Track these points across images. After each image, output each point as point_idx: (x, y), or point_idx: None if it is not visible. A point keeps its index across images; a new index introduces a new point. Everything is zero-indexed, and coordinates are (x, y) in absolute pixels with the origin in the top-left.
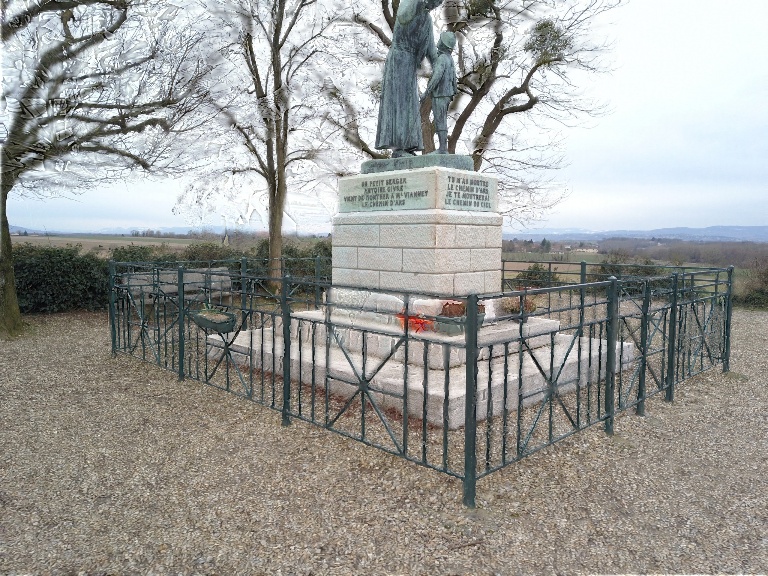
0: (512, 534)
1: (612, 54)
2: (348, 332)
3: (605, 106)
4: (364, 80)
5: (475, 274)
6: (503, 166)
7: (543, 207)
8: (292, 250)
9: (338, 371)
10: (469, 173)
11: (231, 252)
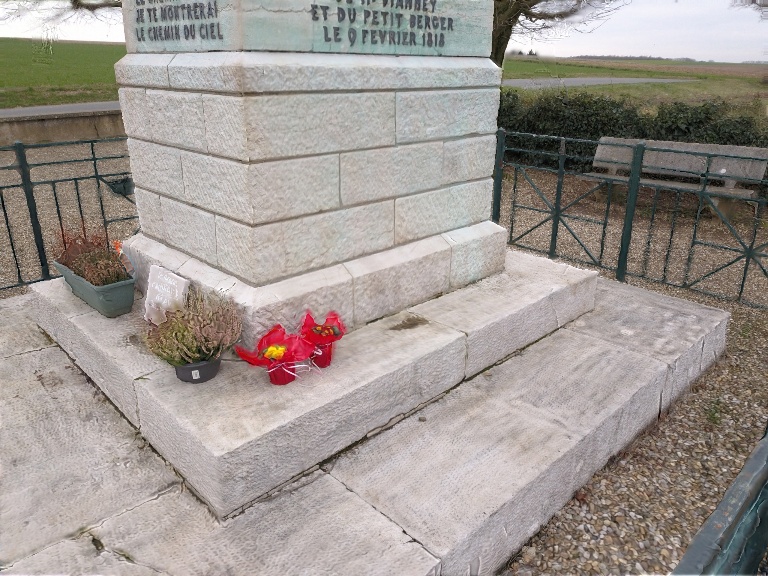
0: None
1: None
2: None
3: None
4: None
5: (197, 212)
6: None
7: None
8: None
9: None
10: None
11: None
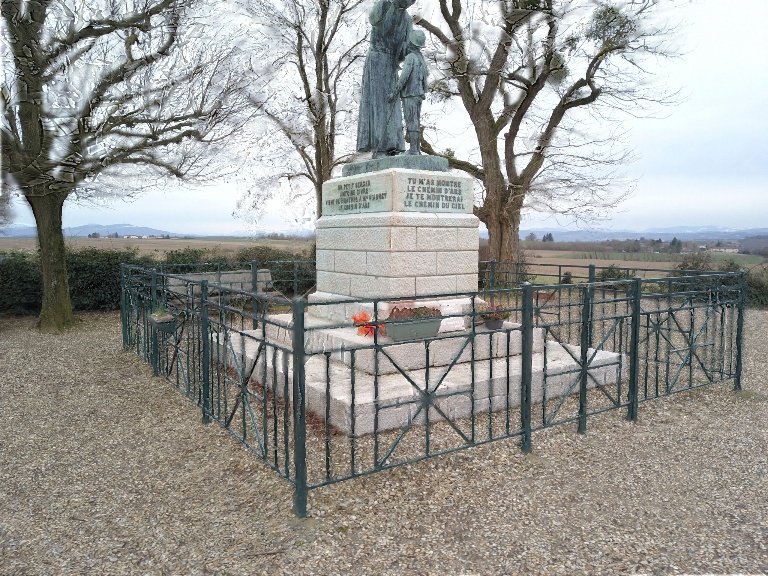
0: (324, 547)
1: (679, 37)
2: (312, 334)
3: (675, 94)
4: None
5: (444, 278)
6: (567, 163)
7: (605, 206)
8: None
9: (280, 372)
10: (436, 174)
11: (281, 254)
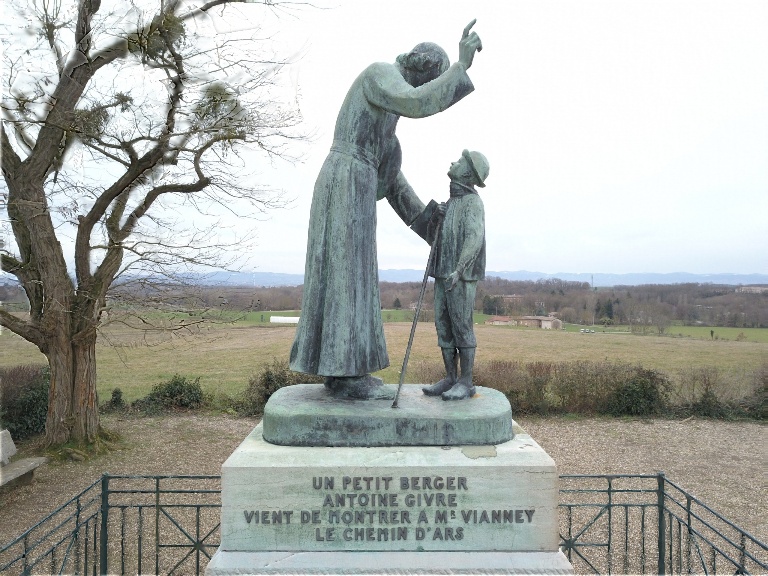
0: None
1: (306, 145)
2: None
3: None
4: None
5: None
6: (152, 260)
7: (225, 322)
8: None
9: None
10: None
11: None
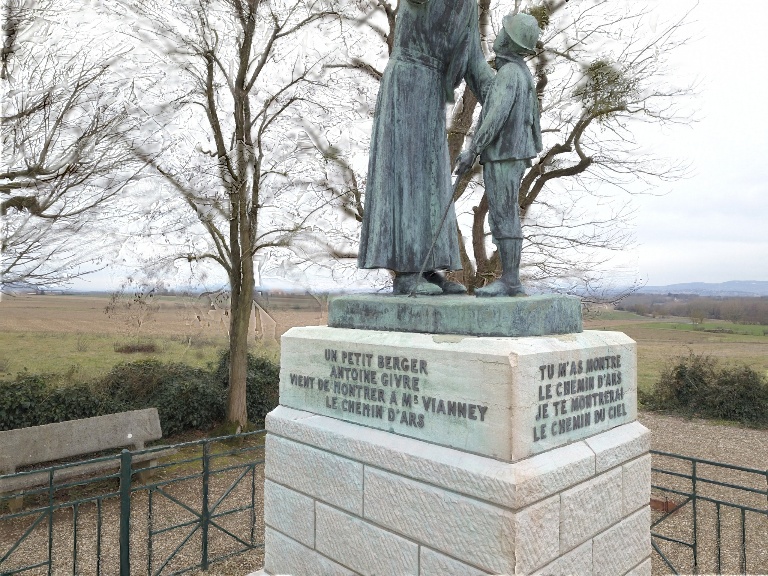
0: None
1: (696, 100)
2: None
3: None
4: (367, 139)
5: None
6: (545, 244)
7: (605, 302)
8: (265, 365)
9: None
10: (582, 343)
11: (176, 373)
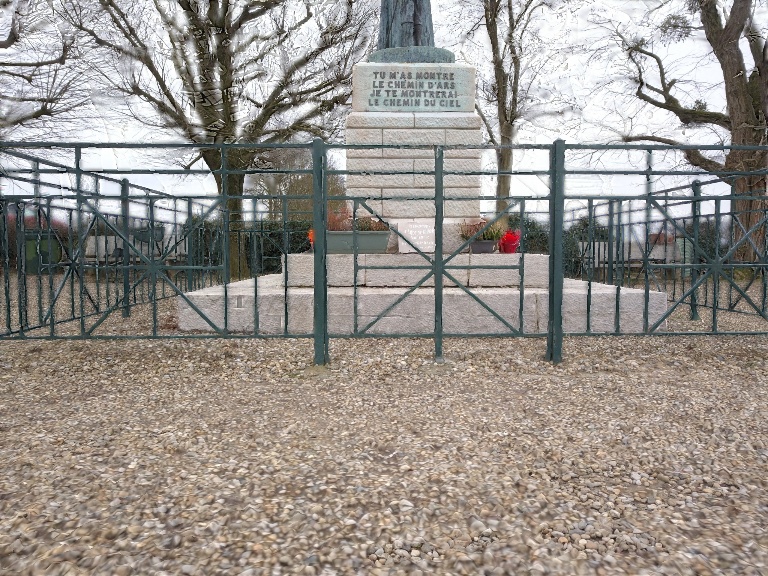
0: None
1: None
2: None
3: None
4: None
5: (425, 191)
6: None
7: None
8: None
9: None
10: (416, 65)
11: None
